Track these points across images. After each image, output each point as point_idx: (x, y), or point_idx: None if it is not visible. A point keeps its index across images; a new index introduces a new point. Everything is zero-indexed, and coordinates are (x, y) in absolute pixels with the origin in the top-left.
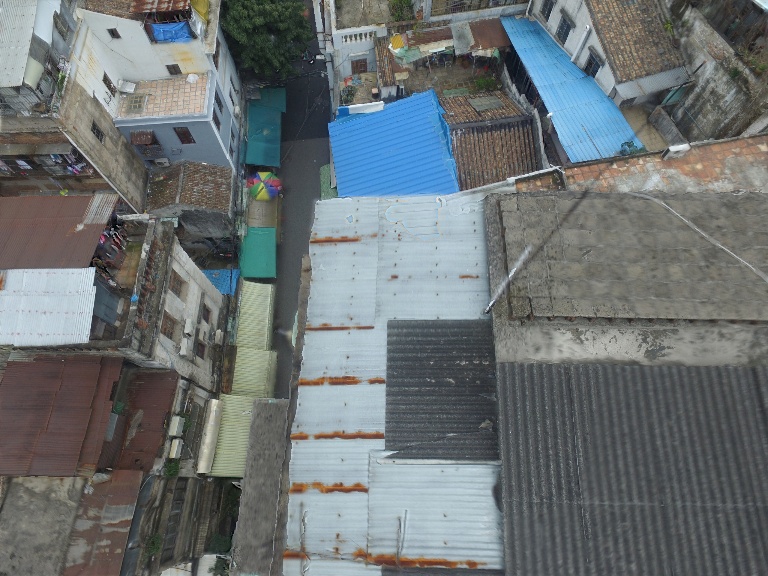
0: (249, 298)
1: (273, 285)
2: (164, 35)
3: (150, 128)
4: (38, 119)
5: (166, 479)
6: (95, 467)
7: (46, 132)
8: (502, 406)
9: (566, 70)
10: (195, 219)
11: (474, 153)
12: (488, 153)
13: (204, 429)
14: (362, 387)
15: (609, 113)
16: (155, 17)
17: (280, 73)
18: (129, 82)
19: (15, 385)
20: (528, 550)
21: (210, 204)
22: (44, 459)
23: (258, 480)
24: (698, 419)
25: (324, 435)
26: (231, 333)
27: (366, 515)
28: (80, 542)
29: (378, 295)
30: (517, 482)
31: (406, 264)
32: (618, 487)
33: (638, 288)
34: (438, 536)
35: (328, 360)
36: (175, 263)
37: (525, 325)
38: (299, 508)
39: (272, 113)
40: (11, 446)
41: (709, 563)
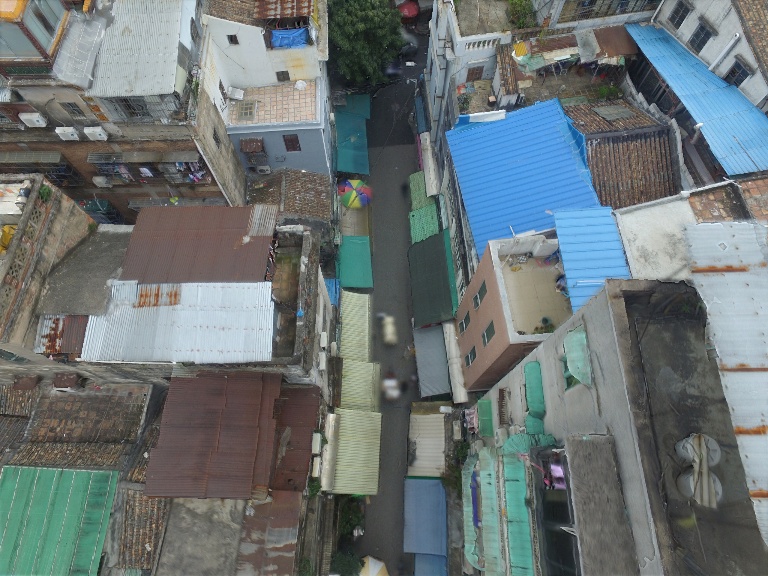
0: (349, 308)
1: (370, 295)
2: (281, 41)
3: (260, 135)
4: (174, 127)
5: (308, 498)
6: (267, 489)
7: (177, 140)
8: None
9: (706, 79)
10: None
11: (609, 164)
12: (623, 164)
13: None
14: None
15: (760, 124)
16: (277, 23)
17: (370, 80)
18: (238, 89)
19: (181, 402)
20: None
21: (312, 212)
22: (219, 480)
23: (595, 526)
24: None
25: None
26: (338, 345)
27: None
28: (247, 566)
29: None
30: None
31: None
32: None
33: None
34: None
35: (761, 406)
36: None
37: None
38: None
39: (357, 120)
40: (185, 466)
41: None
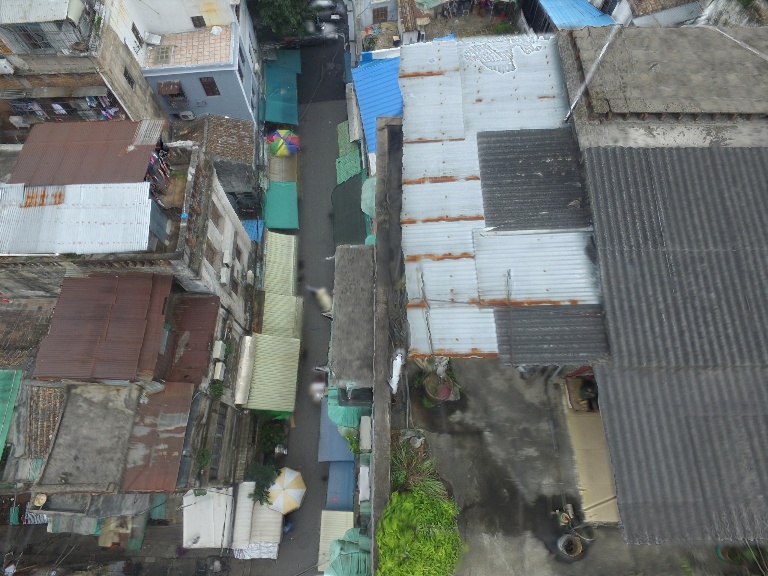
0: (274, 248)
1: (296, 236)
2: None
3: (177, 78)
4: (77, 59)
5: (211, 400)
6: (153, 373)
7: (83, 73)
8: (591, 179)
9: (583, 9)
10: (220, 171)
11: None
12: None
13: (239, 363)
14: (459, 183)
15: None
16: None
17: (296, 33)
18: (155, 34)
19: (73, 298)
20: (622, 285)
21: (235, 155)
22: (105, 363)
23: (347, 309)
24: (761, 187)
25: (430, 219)
26: (259, 278)
27: (475, 275)
28: (139, 446)
29: (465, 115)
30: (609, 235)
31: (488, 90)
32: (696, 238)
33: (701, 91)
34: (540, 286)
35: (426, 165)
36: (214, 195)
37: (603, 124)
38: (415, 272)
39: (288, 74)
40: (74, 352)
41: None
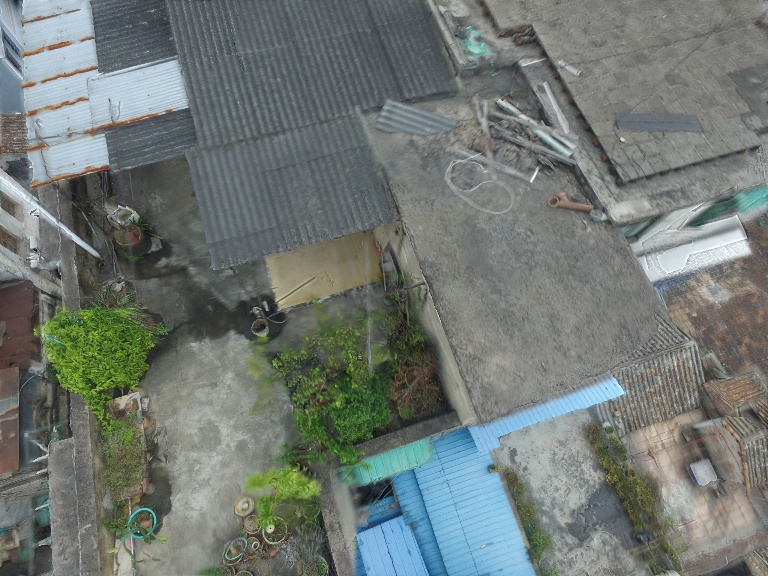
0: None
1: None
2: None
3: None
4: None
5: (54, 384)
6: None
7: None
8: (171, 11)
9: None
10: (26, 171)
11: None
12: None
13: None
14: (76, 45)
15: None
16: None
17: None
18: None
19: None
20: (202, 86)
21: None
22: None
23: (52, 203)
24: None
25: (49, 79)
26: None
27: (90, 113)
28: None
29: None
30: (189, 51)
31: None
32: (263, 40)
33: None
34: (145, 107)
35: (46, 37)
36: None
37: None
38: (35, 122)
39: None
40: None
41: (329, 67)
